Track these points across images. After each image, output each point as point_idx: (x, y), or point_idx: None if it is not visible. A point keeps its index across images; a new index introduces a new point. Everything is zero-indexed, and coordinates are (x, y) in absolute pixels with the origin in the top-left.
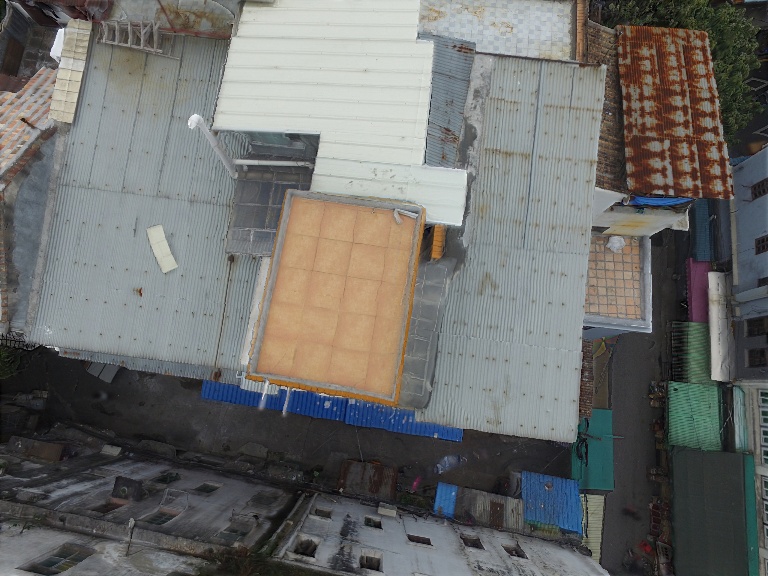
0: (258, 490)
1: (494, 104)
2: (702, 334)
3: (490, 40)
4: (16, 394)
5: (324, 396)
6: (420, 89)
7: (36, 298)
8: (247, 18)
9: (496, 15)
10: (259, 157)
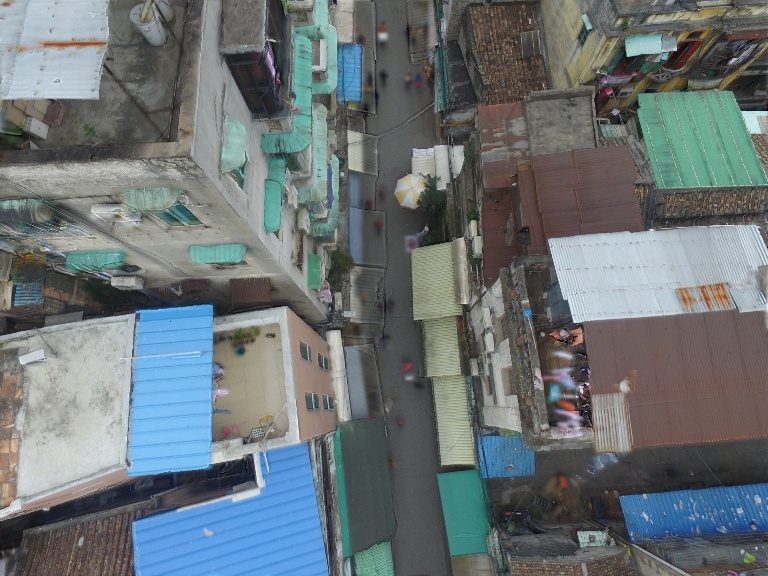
0: None
1: None
2: None
3: None
4: None
5: (766, 508)
6: None
7: None
8: None
9: None
10: None
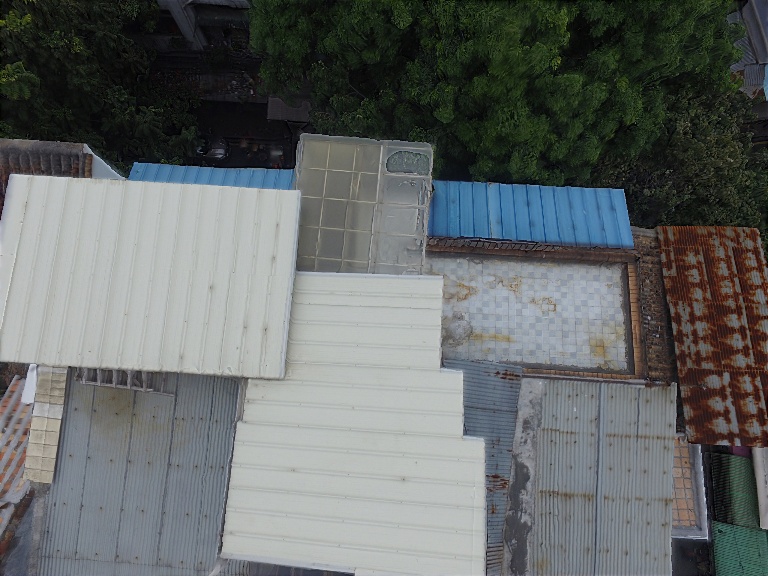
0: None
1: (547, 436)
2: (745, 470)
3: (531, 323)
4: None
5: None
6: (473, 511)
7: None
8: (254, 395)
9: (535, 288)
10: None
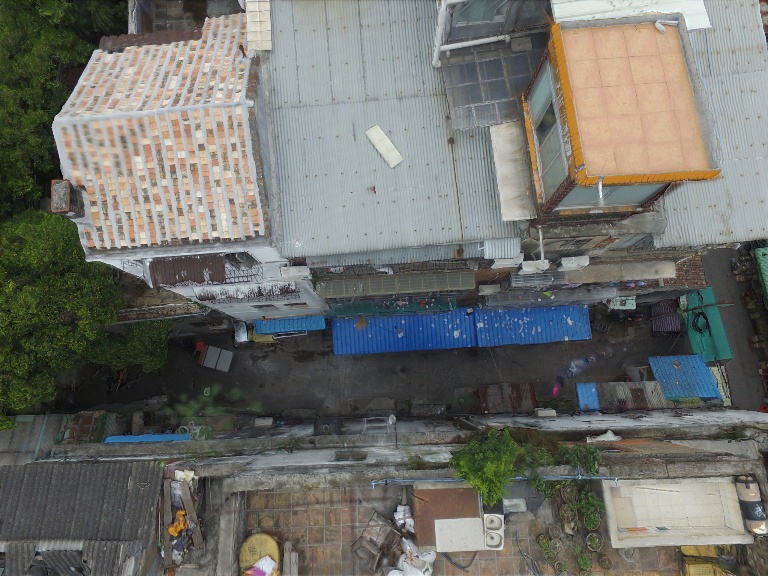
0: None
1: None
2: None
3: None
4: (143, 400)
5: (452, 327)
6: None
7: (278, 217)
8: None
9: None
10: (459, 41)
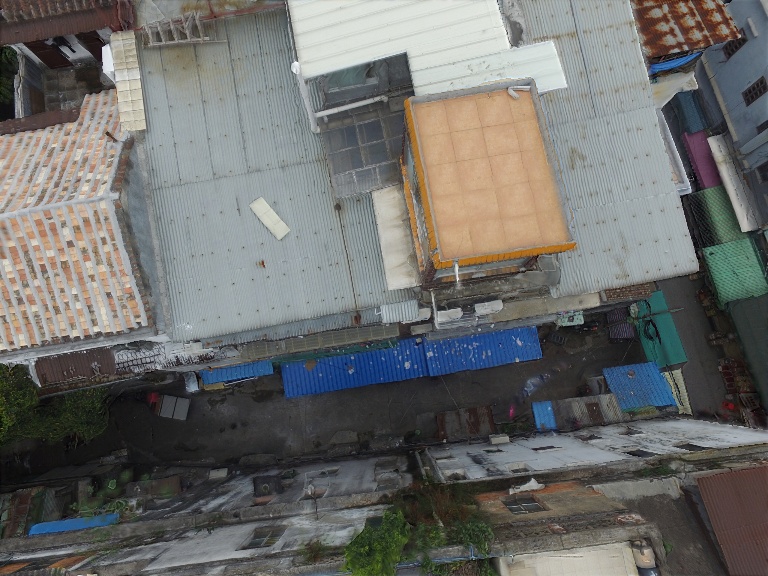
0: (374, 461)
1: None
2: (719, 196)
3: None
4: (100, 458)
5: (402, 358)
6: None
7: (166, 300)
8: None
9: None
10: (336, 105)
